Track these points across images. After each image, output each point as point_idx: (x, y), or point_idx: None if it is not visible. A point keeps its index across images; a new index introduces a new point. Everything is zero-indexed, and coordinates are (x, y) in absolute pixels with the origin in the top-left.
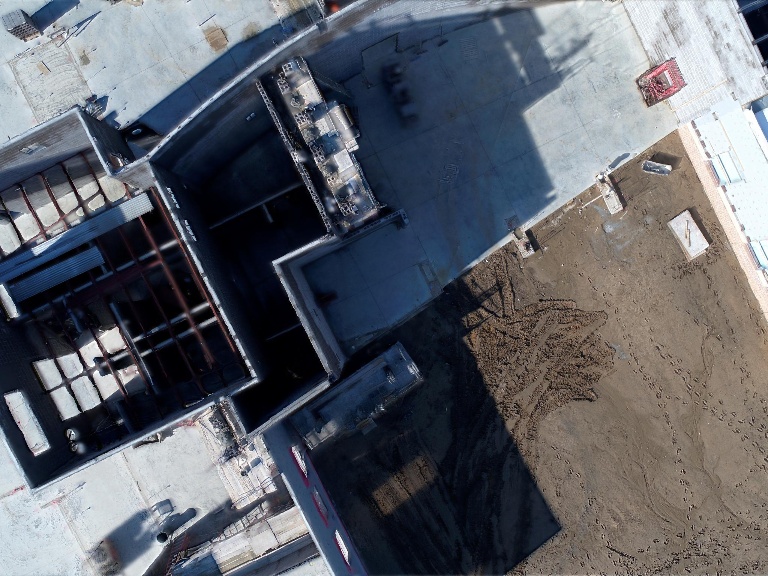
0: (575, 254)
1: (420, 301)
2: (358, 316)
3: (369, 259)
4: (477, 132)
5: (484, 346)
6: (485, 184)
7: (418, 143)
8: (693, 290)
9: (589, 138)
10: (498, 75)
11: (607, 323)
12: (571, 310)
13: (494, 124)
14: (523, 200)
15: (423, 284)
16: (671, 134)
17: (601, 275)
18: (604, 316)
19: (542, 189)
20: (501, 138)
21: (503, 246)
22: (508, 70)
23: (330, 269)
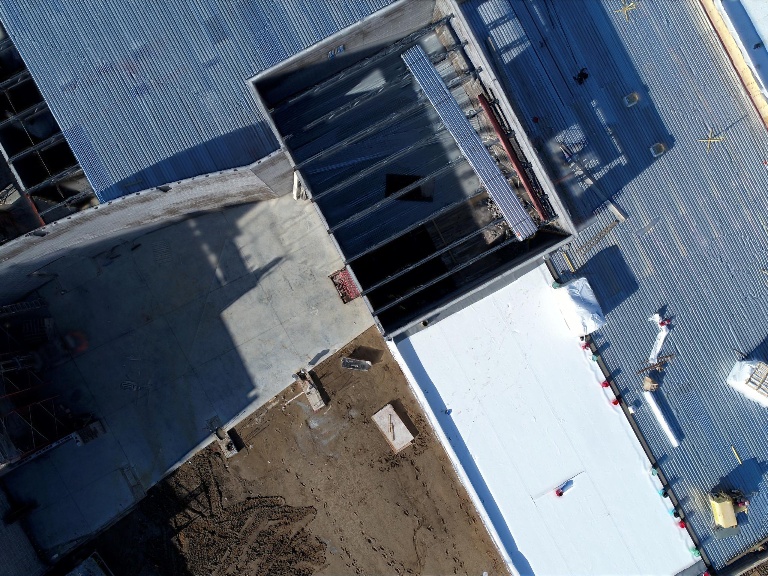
0: (281, 451)
1: (123, 506)
2: (61, 523)
3: (70, 466)
4: (174, 334)
5: (193, 546)
6: (185, 386)
7: (115, 347)
8: (402, 482)
9: (288, 336)
10: (193, 276)
11: (317, 518)
12: (280, 507)
13: (191, 325)
14: (224, 400)
15: (126, 488)
16: (371, 328)
17: (308, 471)
18: (313, 511)
19: (242, 388)
20: (199, 339)
21: (206, 447)
22: (203, 271)
23: (31, 477)
